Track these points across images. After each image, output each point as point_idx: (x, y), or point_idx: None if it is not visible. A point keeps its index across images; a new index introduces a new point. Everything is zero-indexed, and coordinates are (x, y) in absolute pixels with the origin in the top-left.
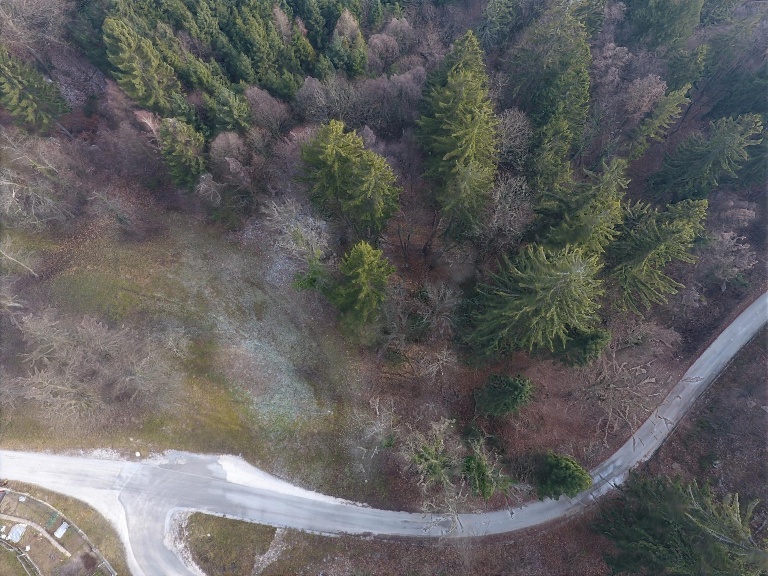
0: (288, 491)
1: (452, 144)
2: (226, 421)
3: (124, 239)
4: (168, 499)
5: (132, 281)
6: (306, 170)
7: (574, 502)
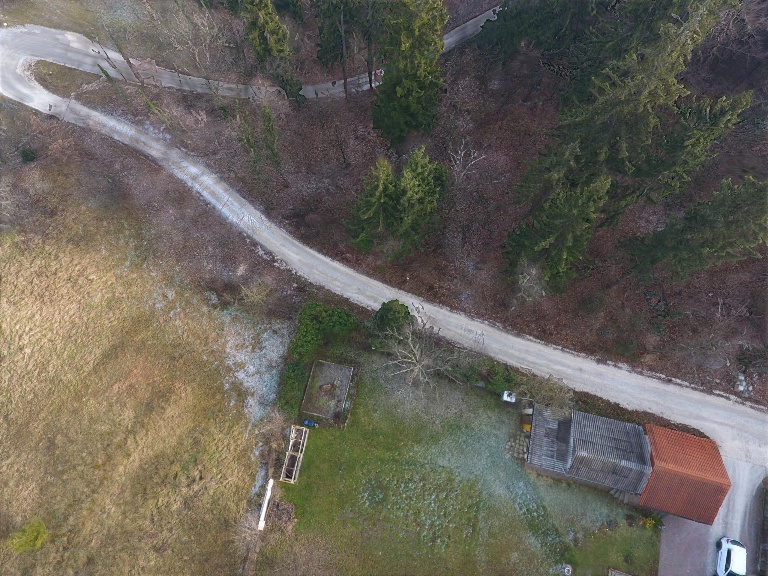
0: (115, 57)
1: None
2: (77, 18)
3: None
4: (24, 50)
5: None
6: None
7: (339, 90)
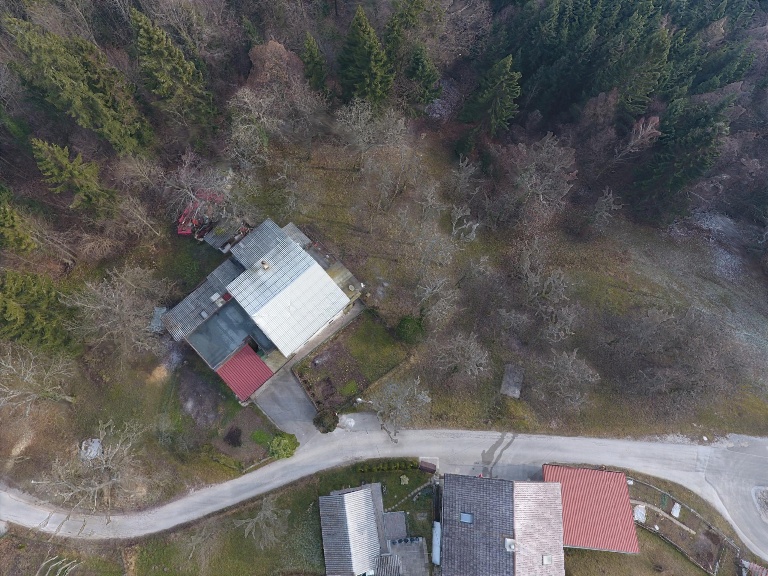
0: None
1: None
2: (758, 406)
3: (572, 239)
4: (746, 479)
5: (617, 278)
6: None
7: None
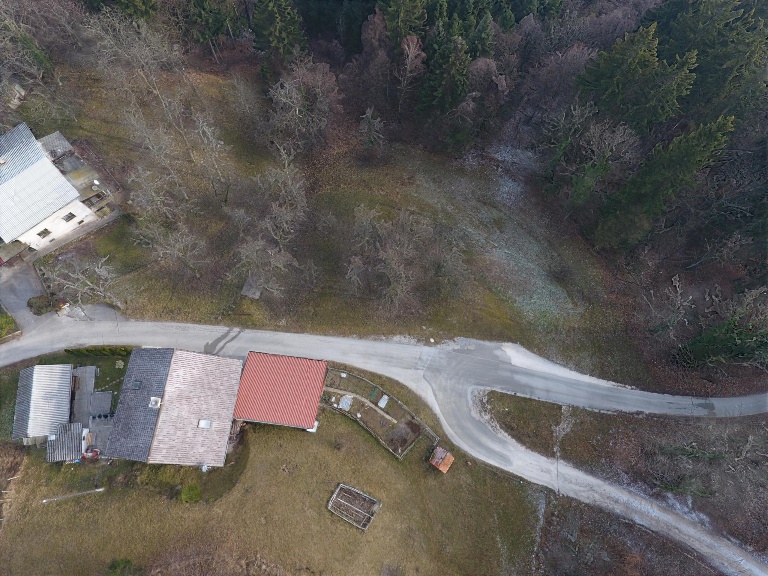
0: (566, 374)
1: (723, 56)
2: (498, 315)
3: (361, 164)
4: (466, 378)
5: (387, 197)
6: (581, 83)
7: None
